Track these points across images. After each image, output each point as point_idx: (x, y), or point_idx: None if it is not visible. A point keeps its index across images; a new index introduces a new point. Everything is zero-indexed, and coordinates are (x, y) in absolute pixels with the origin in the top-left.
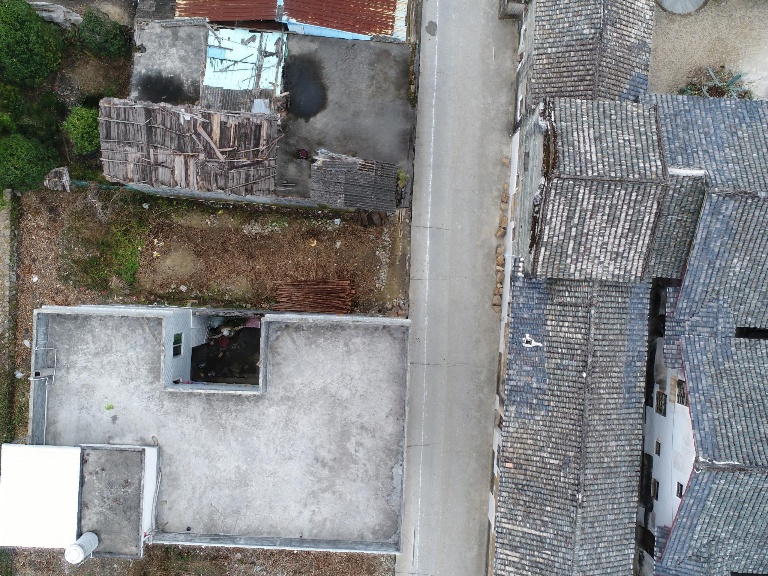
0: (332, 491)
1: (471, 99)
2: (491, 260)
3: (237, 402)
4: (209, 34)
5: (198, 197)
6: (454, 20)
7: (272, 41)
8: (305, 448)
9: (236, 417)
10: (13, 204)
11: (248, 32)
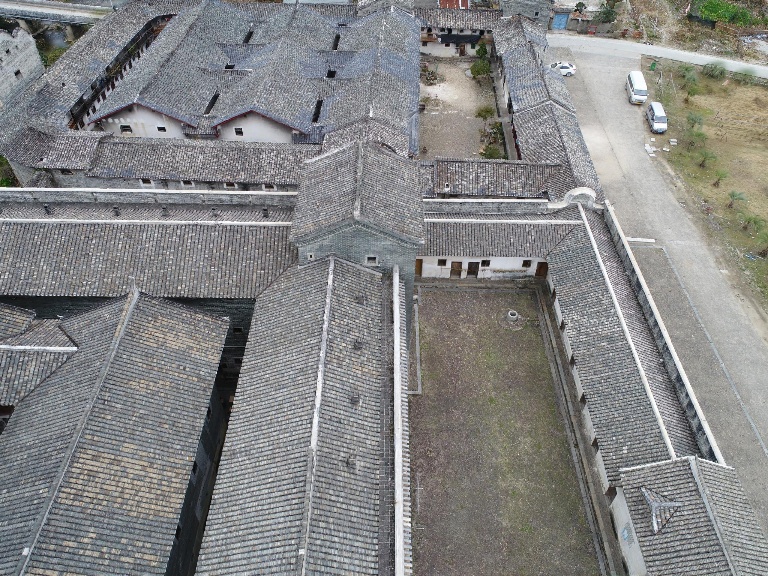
0: None
1: None
2: None
3: None
4: None
5: None
6: None
7: None
8: None
9: None
10: None
11: None
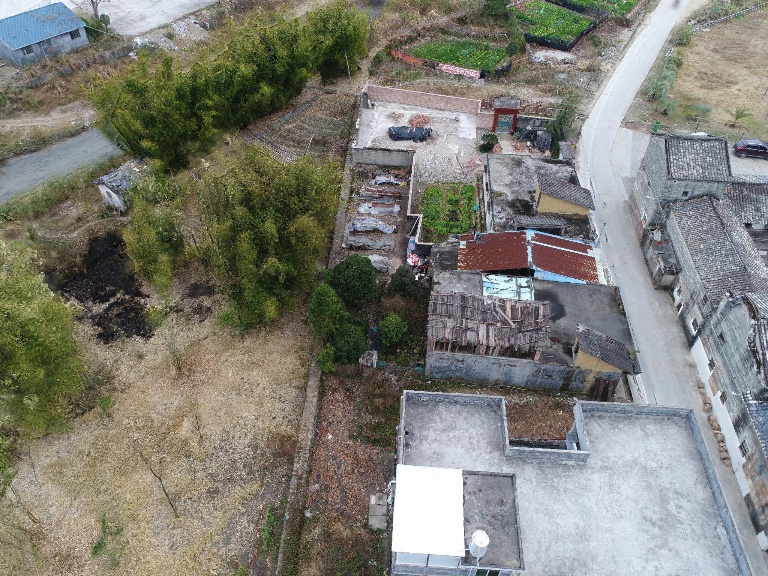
0: (668, 548)
1: (652, 329)
2: (707, 428)
3: (564, 469)
4: (483, 277)
5: (466, 380)
6: (625, 289)
7: (524, 281)
8: (632, 509)
9: (566, 481)
10: (321, 383)
11: (507, 277)
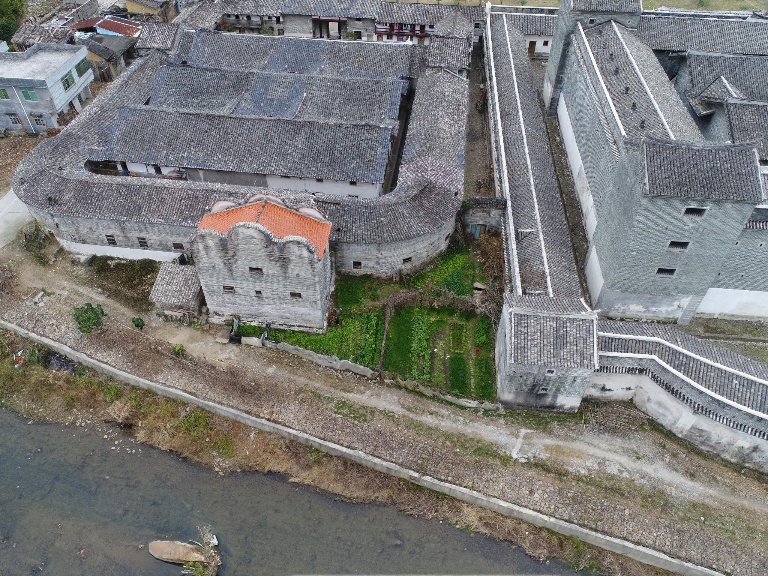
0: None
1: None
2: None
3: (15, 61)
4: None
5: None
6: None
7: None
8: (30, 69)
9: None
10: None
11: None
